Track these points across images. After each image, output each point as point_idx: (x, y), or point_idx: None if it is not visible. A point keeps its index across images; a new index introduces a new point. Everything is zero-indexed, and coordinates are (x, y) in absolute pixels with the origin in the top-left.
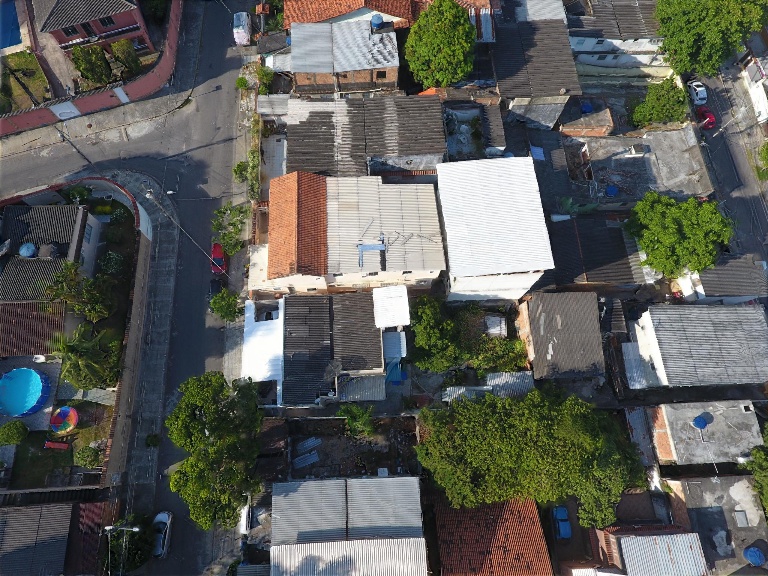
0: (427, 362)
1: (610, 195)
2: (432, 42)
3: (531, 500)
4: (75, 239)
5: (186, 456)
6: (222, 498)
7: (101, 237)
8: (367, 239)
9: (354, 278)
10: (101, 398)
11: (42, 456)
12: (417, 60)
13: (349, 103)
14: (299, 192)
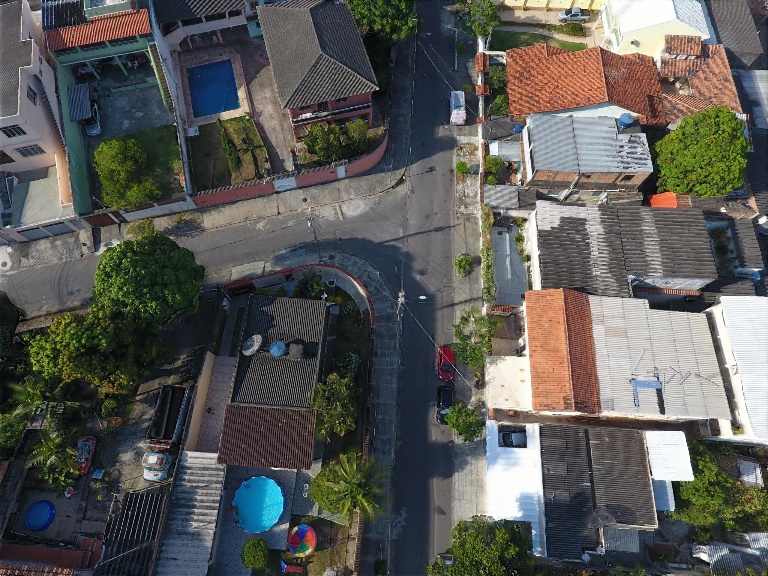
0: (686, 513)
1: None
2: (703, 154)
3: None
4: (321, 339)
5: None
6: None
7: (330, 330)
8: (640, 373)
9: (614, 411)
10: (335, 516)
11: None
12: (674, 168)
13: (601, 210)
14: (567, 313)
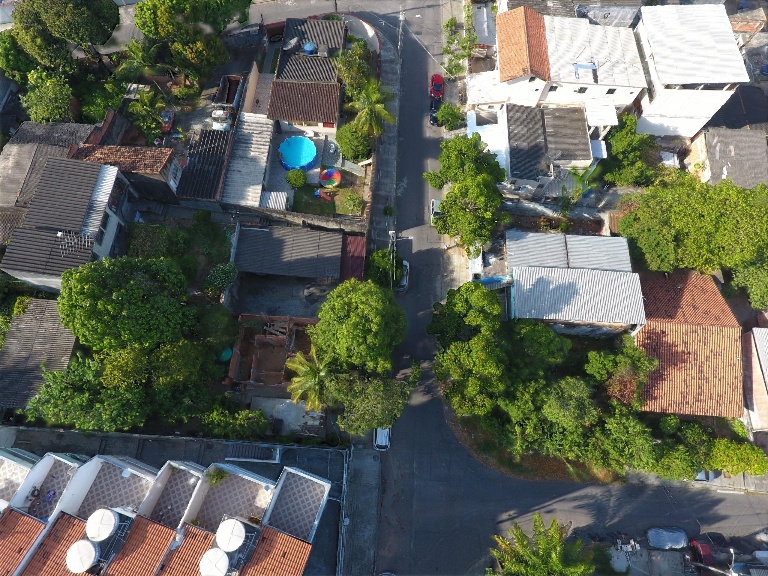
0: (617, 173)
1: (766, 73)
2: None
3: (710, 281)
4: None
5: (416, 224)
6: (487, 213)
7: None
8: (581, 60)
9: (563, 96)
10: (354, 169)
11: (312, 203)
12: None
13: None
14: (526, 20)
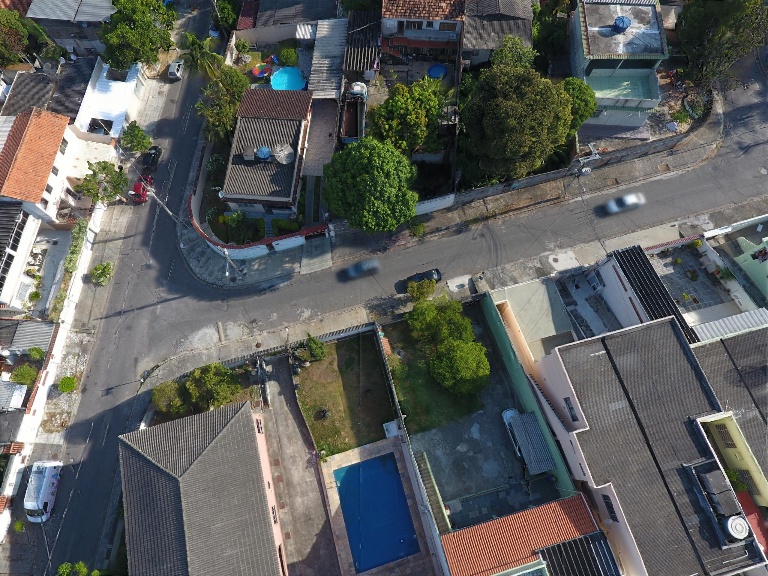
0: None
1: None
2: None
3: None
4: (230, 167)
5: None
6: None
7: None
8: None
9: None
10: None
11: None
12: None
13: None
14: (7, 175)
